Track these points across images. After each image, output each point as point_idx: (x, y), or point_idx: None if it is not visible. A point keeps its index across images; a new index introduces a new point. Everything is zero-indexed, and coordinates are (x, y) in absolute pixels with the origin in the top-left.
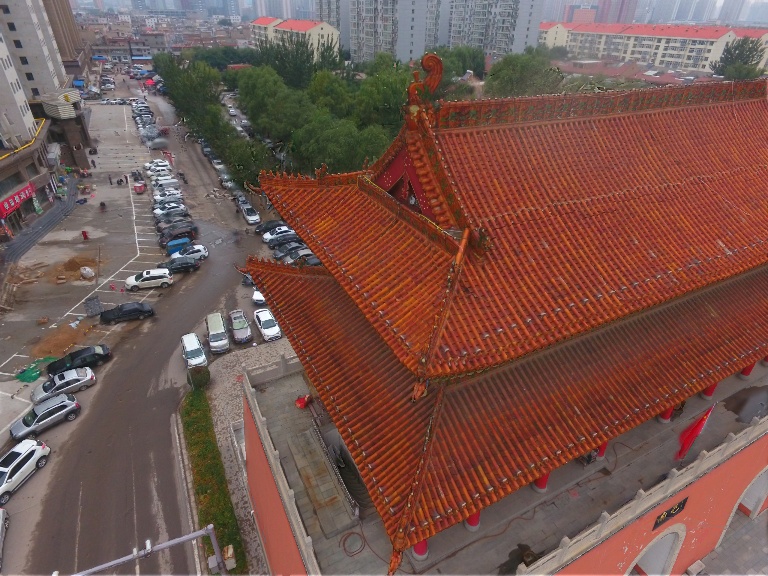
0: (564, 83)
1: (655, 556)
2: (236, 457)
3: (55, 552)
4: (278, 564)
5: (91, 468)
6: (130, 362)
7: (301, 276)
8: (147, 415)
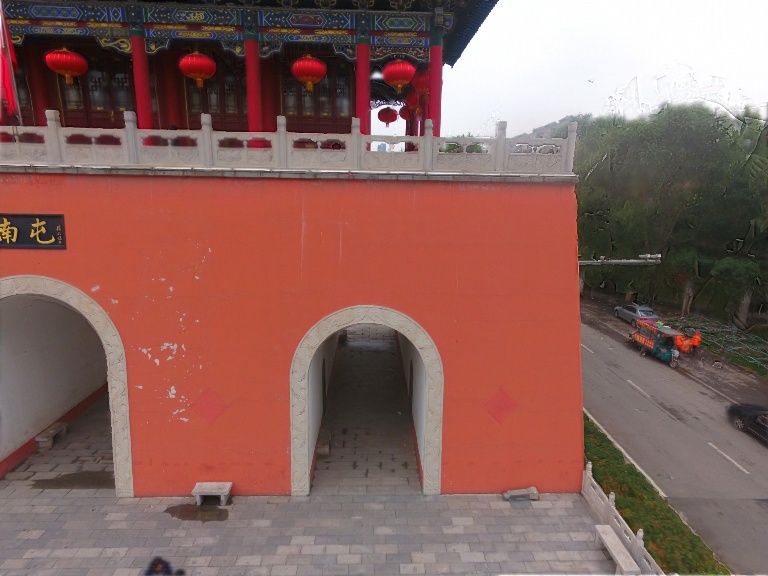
0: None
1: None
2: None
3: None
4: None
5: None
6: None
7: None
8: None
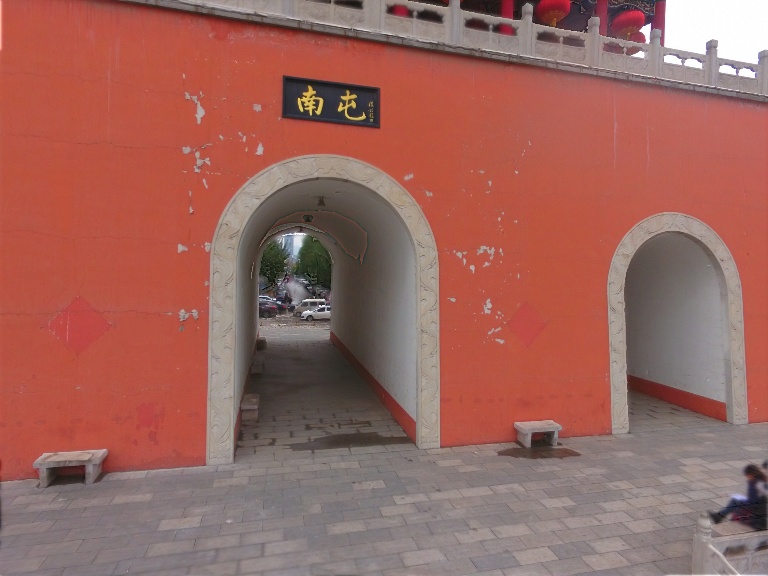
0: None
1: (409, 346)
2: None
3: None
4: None
5: None
6: None
7: None
8: None
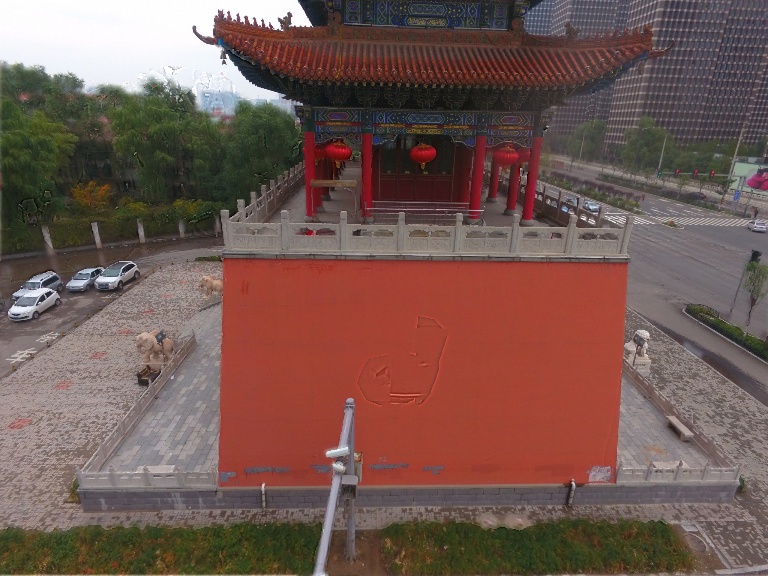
0: (87, 88)
1: None
2: (145, 491)
3: None
4: (385, 436)
5: None
6: None
7: (289, 41)
8: None
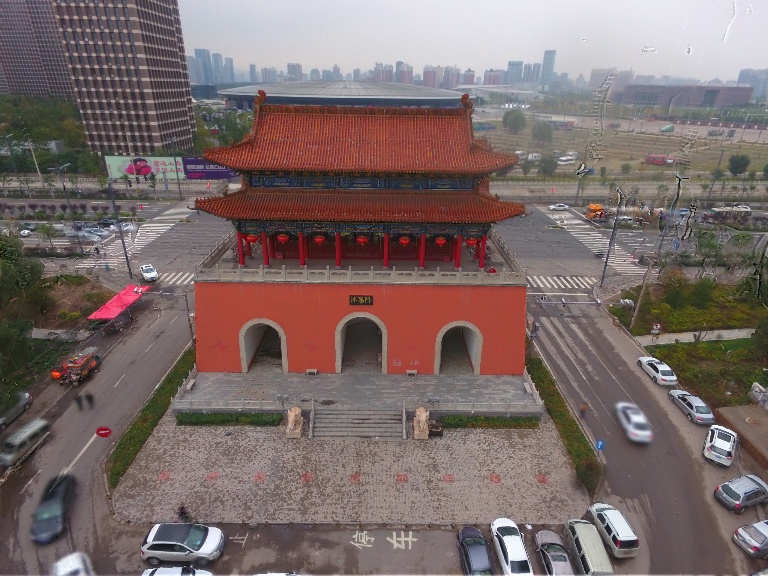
0: None
1: None
2: None
3: (642, 398)
4: None
5: (656, 439)
6: (711, 569)
7: None
8: (634, 472)
